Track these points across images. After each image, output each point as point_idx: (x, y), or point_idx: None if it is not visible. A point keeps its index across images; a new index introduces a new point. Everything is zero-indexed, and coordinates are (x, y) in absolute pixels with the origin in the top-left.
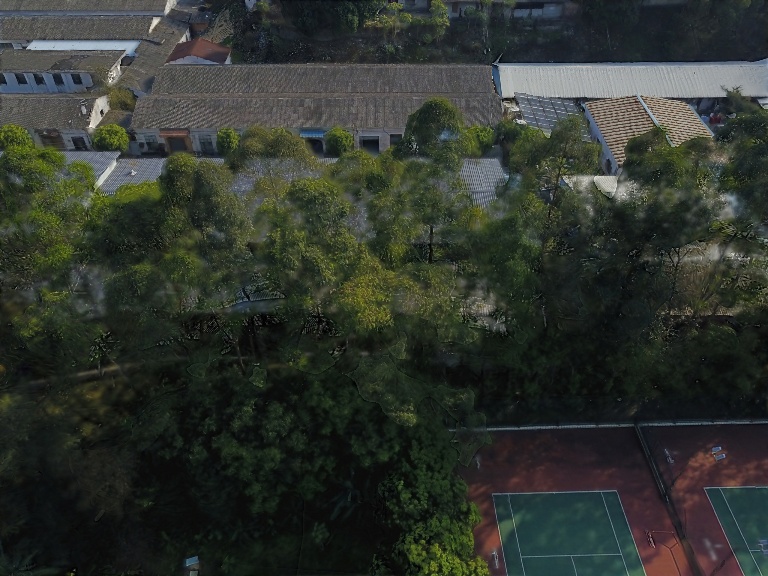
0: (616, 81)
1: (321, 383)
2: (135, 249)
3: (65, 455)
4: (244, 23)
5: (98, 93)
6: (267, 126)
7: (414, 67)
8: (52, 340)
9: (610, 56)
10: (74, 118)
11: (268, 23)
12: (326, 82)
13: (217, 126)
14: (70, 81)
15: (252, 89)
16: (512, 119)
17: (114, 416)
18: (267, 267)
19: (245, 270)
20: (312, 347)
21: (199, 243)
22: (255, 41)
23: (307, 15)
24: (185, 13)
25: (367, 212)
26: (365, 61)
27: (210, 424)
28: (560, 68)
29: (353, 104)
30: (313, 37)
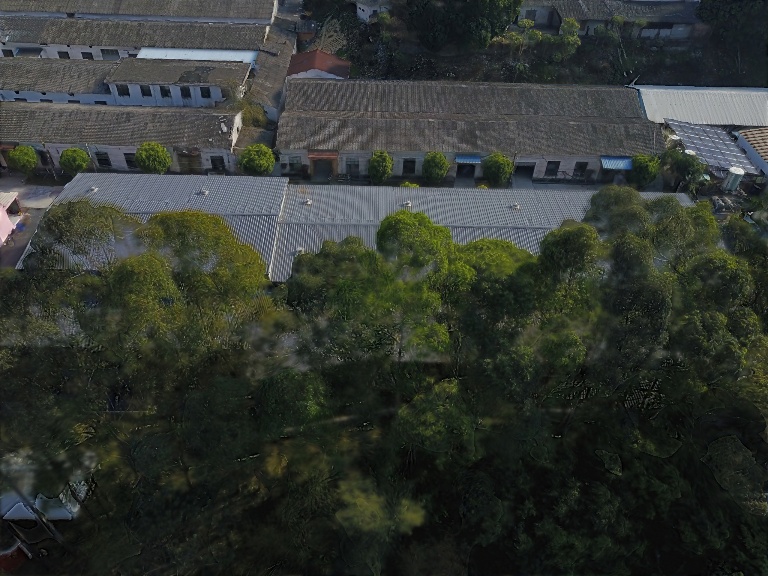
0: (762, 108)
1: (640, 461)
2: (512, 326)
3: (386, 546)
4: (360, 35)
5: (233, 109)
6: (421, 150)
7: (557, 88)
8: (451, 436)
9: (740, 80)
10: (215, 136)
11: (390, 36)
12: (467, 102)
13: (369, 148)
14: (198, 94)
15: (391, 108)
16: (671, 147)
17: (412, 495)
18: (678, 352)
19: (660, 357)
20: (646, 425)
21: (597, 323)
22: (373, 54)
23: (440, 30)
24: (289, 21)
25: (763, 287)
26: (490, 79)
27: (530, 508)
28: (703, 93)
29: (508, 128)
30: (436, 52)
